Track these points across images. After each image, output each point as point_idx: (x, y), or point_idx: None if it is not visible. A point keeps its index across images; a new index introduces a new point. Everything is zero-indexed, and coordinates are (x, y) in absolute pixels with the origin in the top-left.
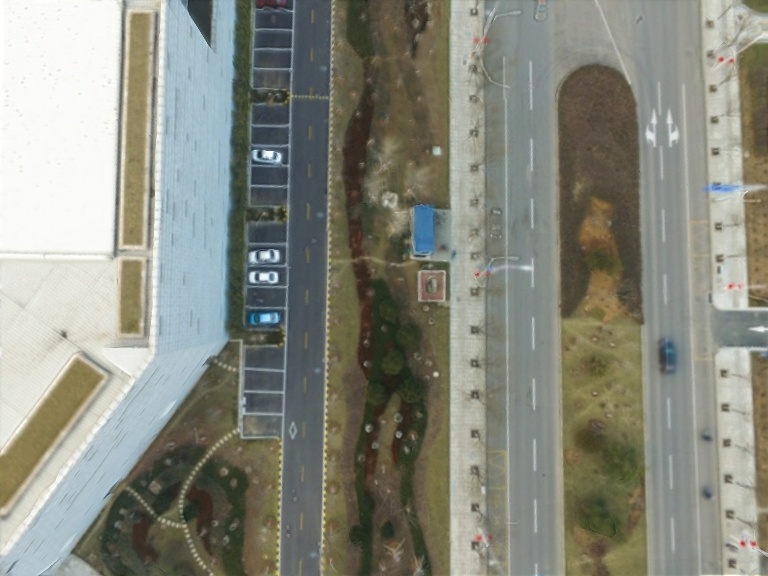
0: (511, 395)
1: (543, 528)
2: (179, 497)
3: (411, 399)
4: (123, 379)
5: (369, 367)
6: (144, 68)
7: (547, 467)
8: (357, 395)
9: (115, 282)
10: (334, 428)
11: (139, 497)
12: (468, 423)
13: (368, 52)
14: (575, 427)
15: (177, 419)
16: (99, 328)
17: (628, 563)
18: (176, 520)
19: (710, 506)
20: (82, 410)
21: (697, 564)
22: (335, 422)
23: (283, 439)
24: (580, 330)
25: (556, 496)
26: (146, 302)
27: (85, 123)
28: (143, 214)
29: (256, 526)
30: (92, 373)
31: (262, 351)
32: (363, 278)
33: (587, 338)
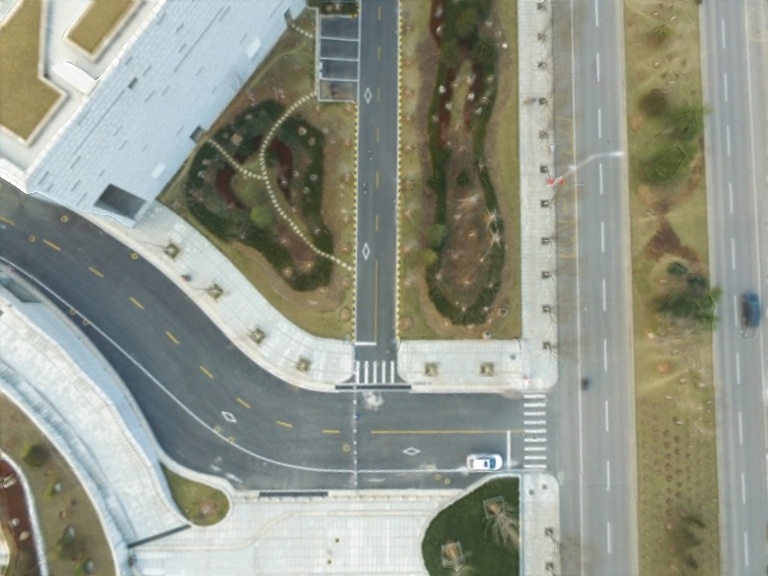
0: (576, 67)
1: (608, 189)
2: (260, 151)
3: (484, 56)
4: None
5: (442, 29)
6: None
7: (611, 134)
8: (429, 63)
9: None
10: (408, 91)
11: (221, 149)
12: (536, 92)
13: None
14: (638, 96)
15: (257, 78)
16: None
17: (689, 221)
18: (257, 172)
19: (765, 172)
20: None
21: (754, 225)
22: (408, 89)
23: (358, 103)
24: (641, 8)
25: (620, 161)
26: None
27: None
28: None
29: (334, 182)
30: None
31: (337, 21)
32: None
33: (648, 15)
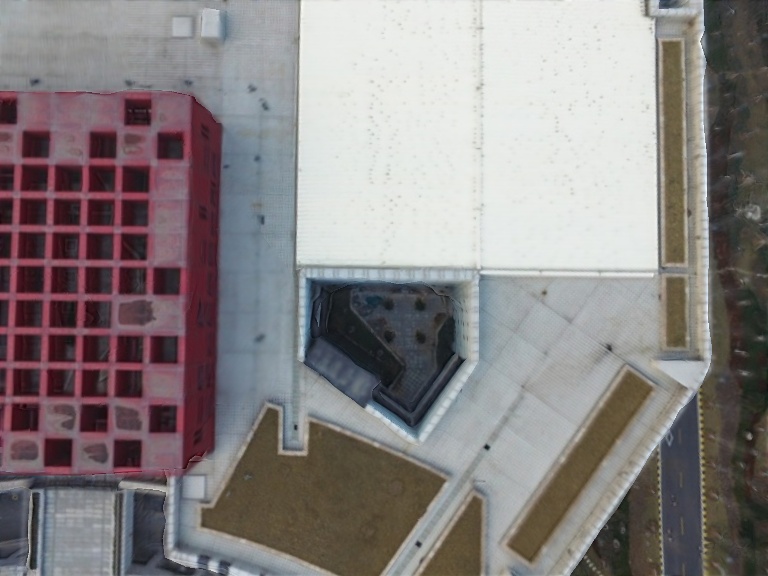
0: None
1: None
2: None
3: None
4: (680, 390)
5: (750, 376)
6: (678, 94)
7: None
8: (731, 403)
9: (656, 298)
10: (712, 435)
11: None
12: None
13: (722, 67)
14: None
15: None
16: (643, 342)
17: None
18: None
19: None
20: (634, 420)
21: None
22: (709, 429)
23: (660, 446)
24: None
25: None
26: (689, 317)
27: (628, 147)
28: (684, 233)
29: (639, 530)
30: (642, 384)
31: None
32: (731, 289)
33: None
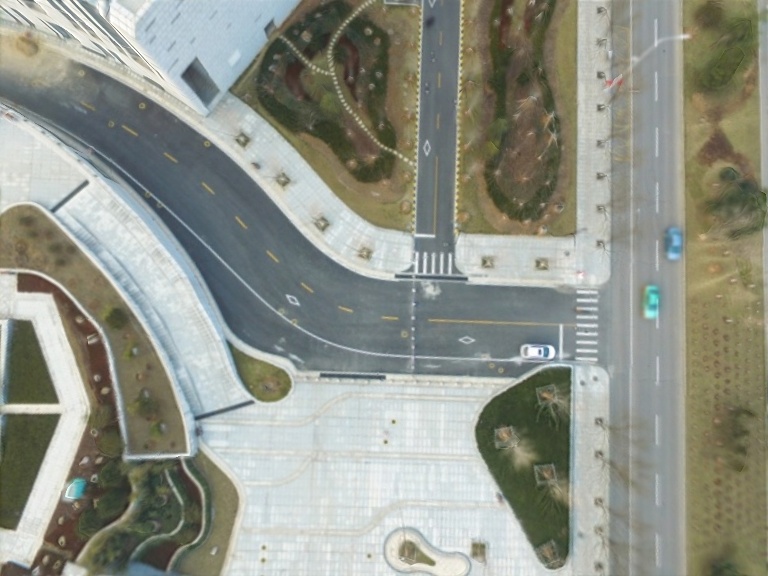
0: None
1: (663, 96)
2: (328, 48)
3: None
4: None
5: None
6: None
7: (667, 44)
8: None
9: None
10: None
11: (292, 45)
12: (595, 1)
13: None
14: (694, 7)
15: None
16: None
17: (743, 129)
18: (325, 69)
19: None
20: None
21: None
22: None
23: (423, 7)
24: None
25: (675, 70)
26: None
27: None
28: None
29: (398, 81)
30: None
31: None
32: None
33: None
